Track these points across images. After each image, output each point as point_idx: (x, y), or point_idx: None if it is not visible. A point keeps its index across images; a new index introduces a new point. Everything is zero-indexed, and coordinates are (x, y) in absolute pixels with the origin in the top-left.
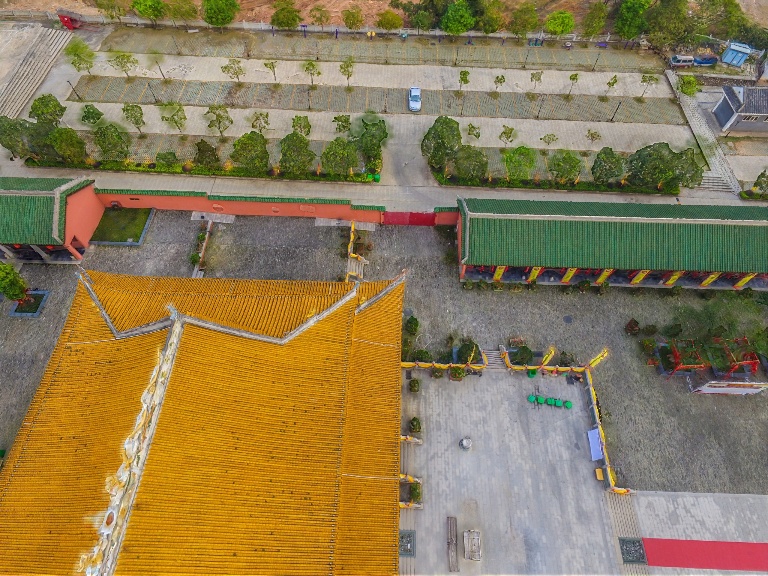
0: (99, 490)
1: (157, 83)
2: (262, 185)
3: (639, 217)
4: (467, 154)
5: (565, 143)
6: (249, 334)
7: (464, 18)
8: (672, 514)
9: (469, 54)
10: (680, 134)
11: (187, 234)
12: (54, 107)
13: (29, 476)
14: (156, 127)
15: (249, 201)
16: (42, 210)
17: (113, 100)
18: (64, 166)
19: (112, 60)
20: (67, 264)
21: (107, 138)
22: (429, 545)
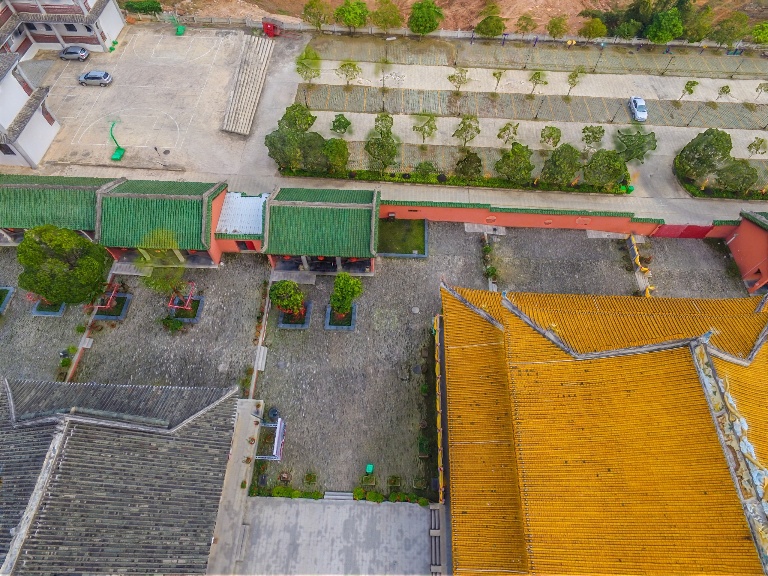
0: (678, 518)
1: (375, 92)
2: (517, 196)
3: None
4: (736, 166)
5: None
6: (731, 357)
7: (676, 27)
8: None
9: (671, 63)
10: None
11: (468, 246)
12: (306, 117)
13: (549, 501)
14: (392, 136)
15: (530, 213)
16: (356, 223)
17: (339, 109)
18: (320, 176)
19: (338, 69)
20: (360, 276)
21: (387, 149)
22: None
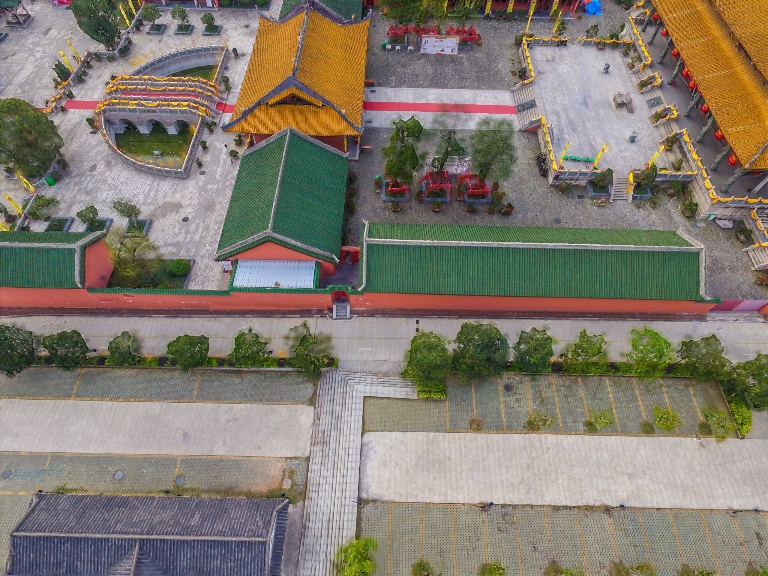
0: None
1: None
2: None
3: (531, 244)
4: None
5: (560, 448)
6: None
7: None
8: (497, 122)
9: None
10: (380, 476)
11: None
12: None
13: None
14: None
15: None
16: None
17: None
18: None
19: None
20: None
21: None
22: (640, 104)
